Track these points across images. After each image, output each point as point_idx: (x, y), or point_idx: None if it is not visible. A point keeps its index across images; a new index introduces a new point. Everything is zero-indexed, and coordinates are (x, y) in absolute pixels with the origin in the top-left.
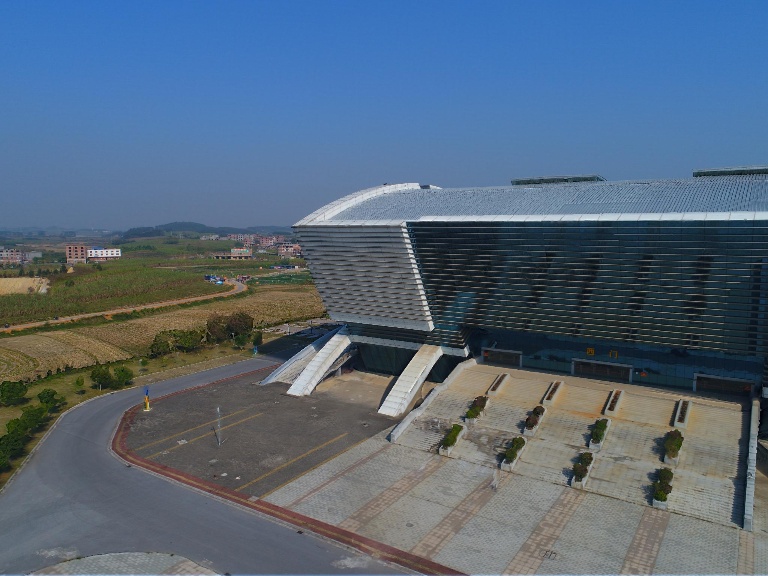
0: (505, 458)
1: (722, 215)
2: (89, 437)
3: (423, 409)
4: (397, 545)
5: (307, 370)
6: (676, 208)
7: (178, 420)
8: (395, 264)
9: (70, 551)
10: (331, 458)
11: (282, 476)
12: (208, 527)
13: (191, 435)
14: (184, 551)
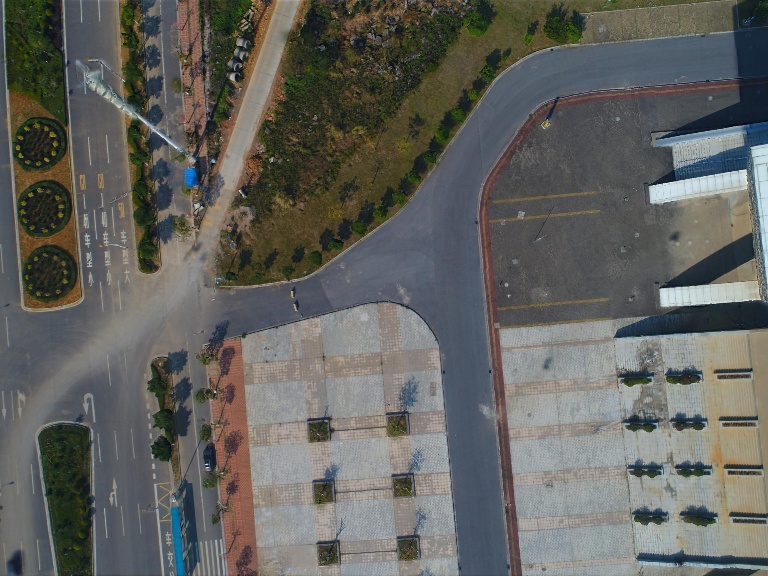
0: (630, 424)
1: None
2: (485, 149)
3: (663, 338)
4: (510, 421)
5: (683, 184)
6: None
7: (546, 170)
8: (762, 282)
9: (408, 297)
10: (567, 322)
11: (527, 317)
12: (463, 331)
13: (532, 209)
14: (442, 340)
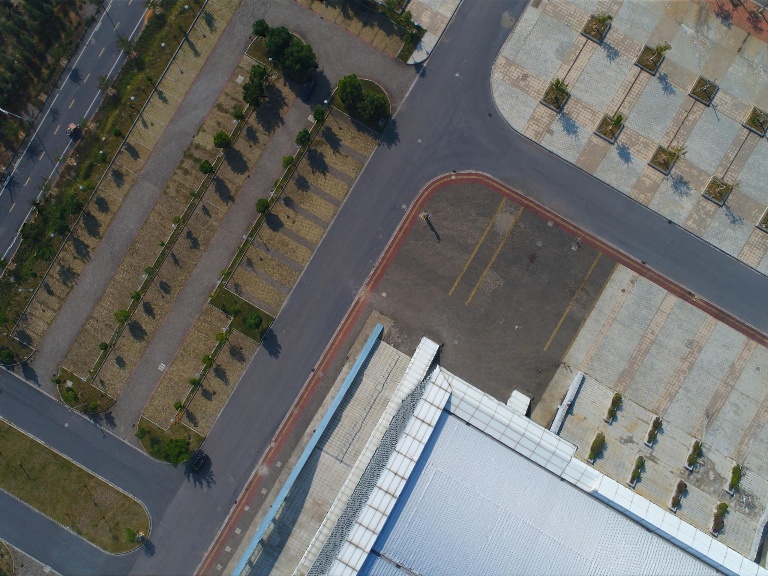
0: None
1: (637, 504)
2: None
3: (760, 526)
4: (764, 349)
5: None
6: (654, 569)
7: None
8: None
9: None
10: None
11: None
12: None
13: None
14: None
